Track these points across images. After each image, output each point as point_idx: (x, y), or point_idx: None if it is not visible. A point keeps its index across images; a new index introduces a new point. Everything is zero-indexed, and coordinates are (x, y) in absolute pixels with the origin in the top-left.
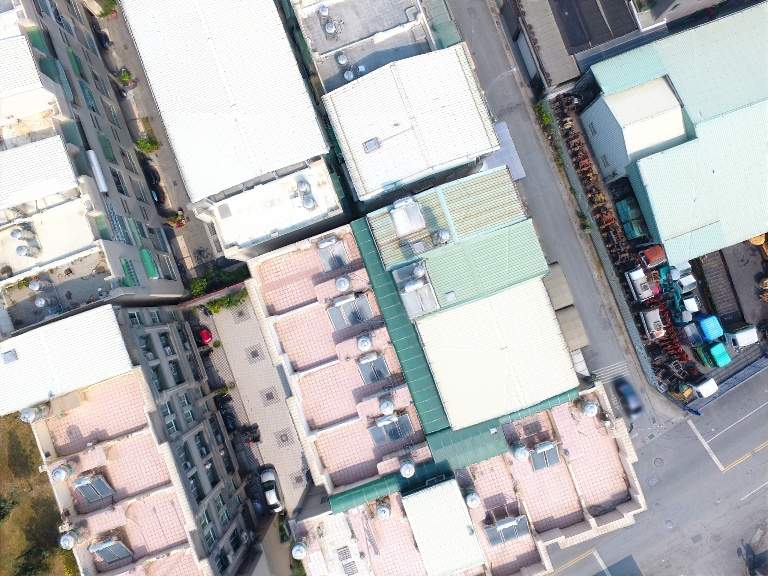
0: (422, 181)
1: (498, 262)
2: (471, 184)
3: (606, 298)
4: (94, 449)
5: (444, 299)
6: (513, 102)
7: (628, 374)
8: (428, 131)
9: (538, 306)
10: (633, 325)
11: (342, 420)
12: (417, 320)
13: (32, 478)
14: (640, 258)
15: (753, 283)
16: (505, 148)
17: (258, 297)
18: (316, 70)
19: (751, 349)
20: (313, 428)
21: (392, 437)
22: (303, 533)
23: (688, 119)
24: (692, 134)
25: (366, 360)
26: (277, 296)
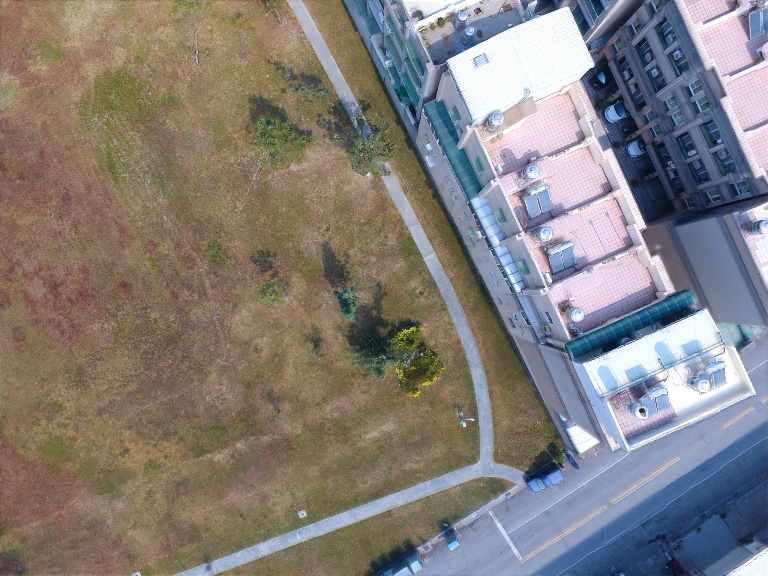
0: None
1: None
2: None
3: None
4: (543, 159)
5: None
6: None
7: None
8: None
9: None
10: None
11: (762, 124)
12: None
13: (349, 287)
14: None
15: None
16: None
17: (685, 5)
18: None
19: None
20: None
21: None
22: (748, 223)
23: None
24: None
25: None
26: (689, 12)
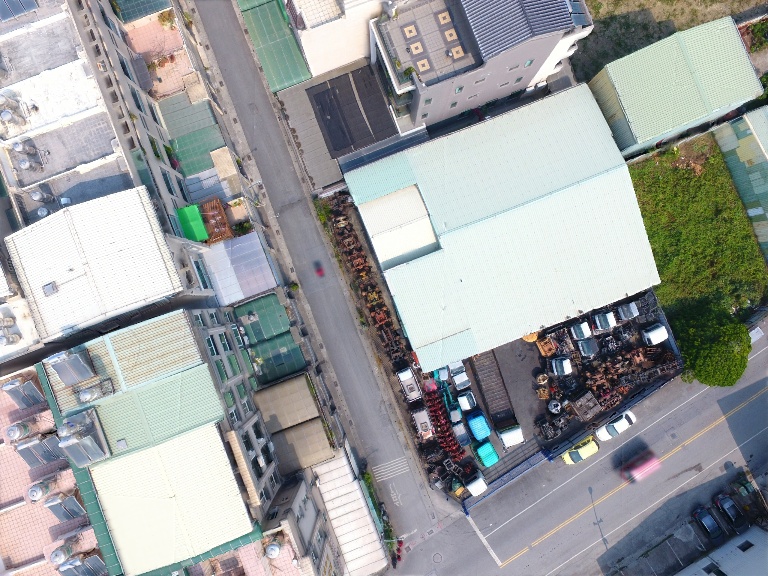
0: (107, 322)
1: (169, 409)
2: (143, 330)
3: (386, 394)
4: None
5: (116, 446)
6: (295, 198)
7: (408, 470)
8: (102, 276)
9: (211, 452)
10: (405, 424)
11: (38, 558)
12: (90, 467)
13: None
14: (412, 357)
15: (530, 378)
16: (255, 258)
17: None
18: (13, 205)
19: (529, 444)
20: (9, 567)
21: (86, 575)
22: None
23: (434, 229)
24: (439, 244)
25: (50, 503)
26: None
